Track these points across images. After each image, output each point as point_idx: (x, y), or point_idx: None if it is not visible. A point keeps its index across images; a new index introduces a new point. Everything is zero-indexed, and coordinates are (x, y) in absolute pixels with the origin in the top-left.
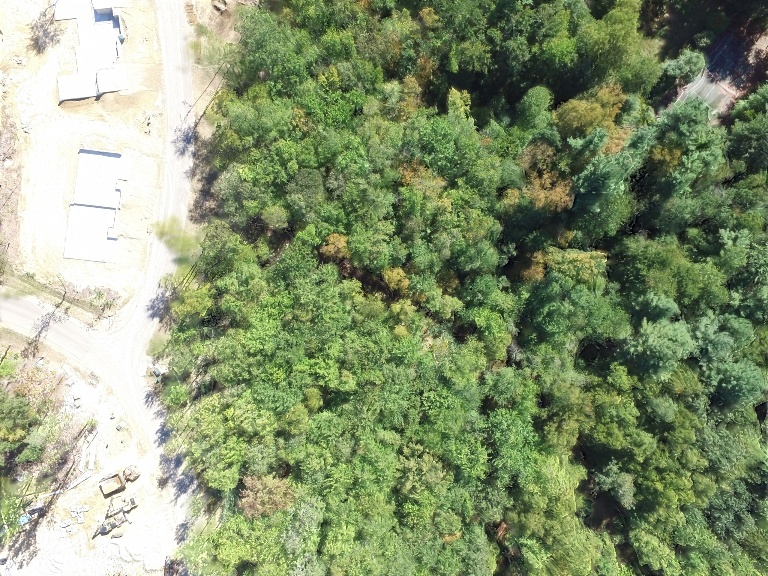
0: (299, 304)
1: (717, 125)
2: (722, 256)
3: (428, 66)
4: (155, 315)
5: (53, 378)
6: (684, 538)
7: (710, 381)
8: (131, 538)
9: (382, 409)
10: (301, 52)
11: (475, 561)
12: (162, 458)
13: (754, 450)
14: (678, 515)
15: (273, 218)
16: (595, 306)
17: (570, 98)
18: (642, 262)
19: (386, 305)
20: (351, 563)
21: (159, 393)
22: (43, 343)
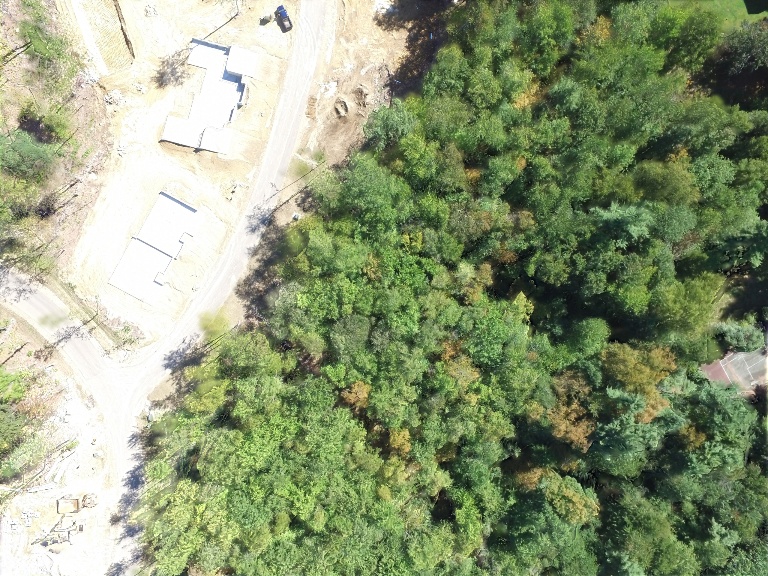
0: (303, 437)
1: (751, 406)
2: (705, 546)
3: (507, 256)
4: (169, 366)
5: (55, 386)
6: None
7: None
8: (66, 558)
9: (339, 560)
10: (397, 204)
11: None
12: (123, 497)
13: None
14: None
15: (311, 346)
16: (570, 547)
17: (625, 340)
18: (630, 516)
19: (381, 454)
20: None
21: (144, 437)
22: (58, 351)
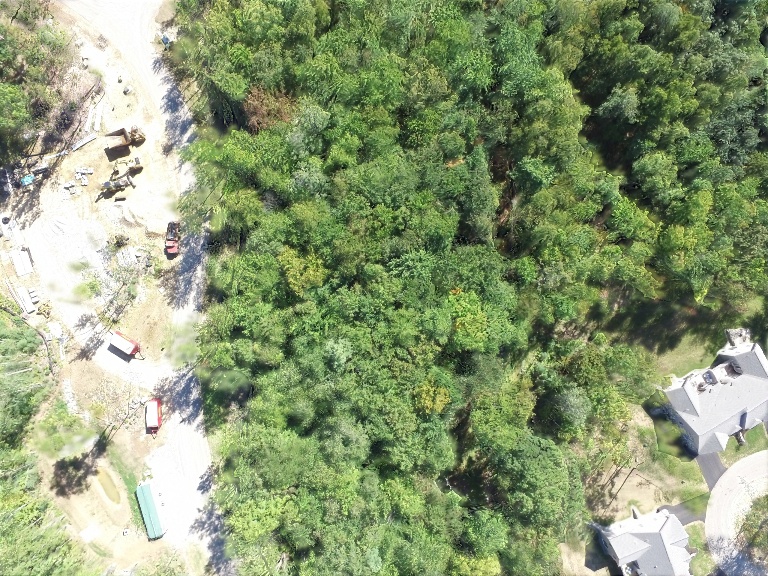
0: None
1: None
2: None
3: None
4: None
5: (62, 39)
6: (687, 149)
7: None
8: (134, 202)
9: (389, 15)
10: None
11: (478, 185)
12: (168, 124)
13: (758, 58)
14: (682, 128)
15: None
16: None
17: None
18: None
19: None
20: (355, 173)
21: (167, 60)
22: (54, 4)
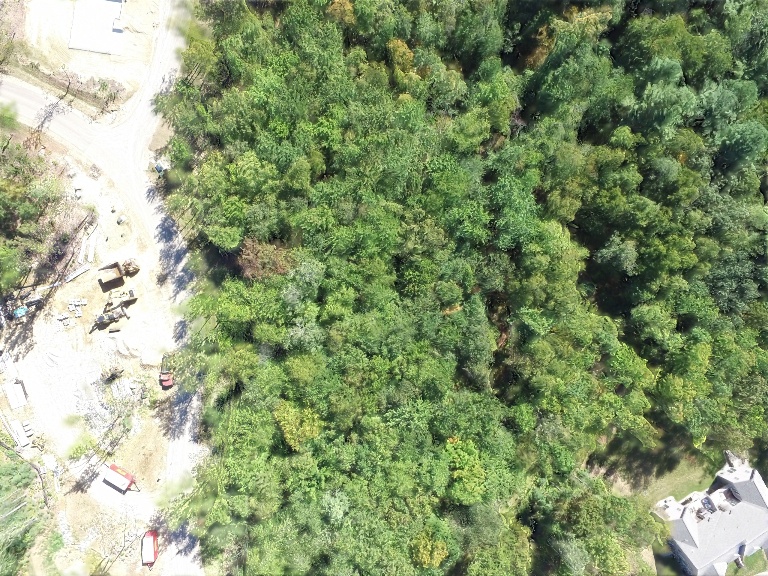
0: (304, 59)
1: None
2: (727, 27)
3: None
4: (159, 110)
5: (55, 169)
6: (686, 303)
7: (714, 143)
8: (129, 334)
9: (385, 168)
10: None
11: (476, 334)
12: (162, 254)
13: (757, 213)
14: (681, 281)
15: None
16: (600, 70)
17: None
18: None
19: None
20: (351, 327)
21: (161, 188)
22: (46, 134)
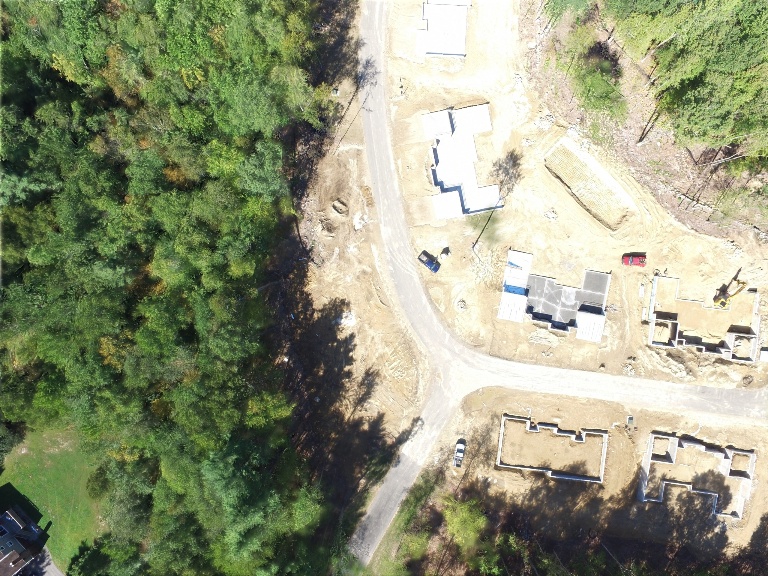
0: None
1: None
2: None
3: None
4: None
5: None
6: None
7: None
8: None
9: None
10: (226, 109)
11: None
12: None
13: None
14: None
15: None
16: None
17: None
18: None
19: None
20: None
21: None
22: None
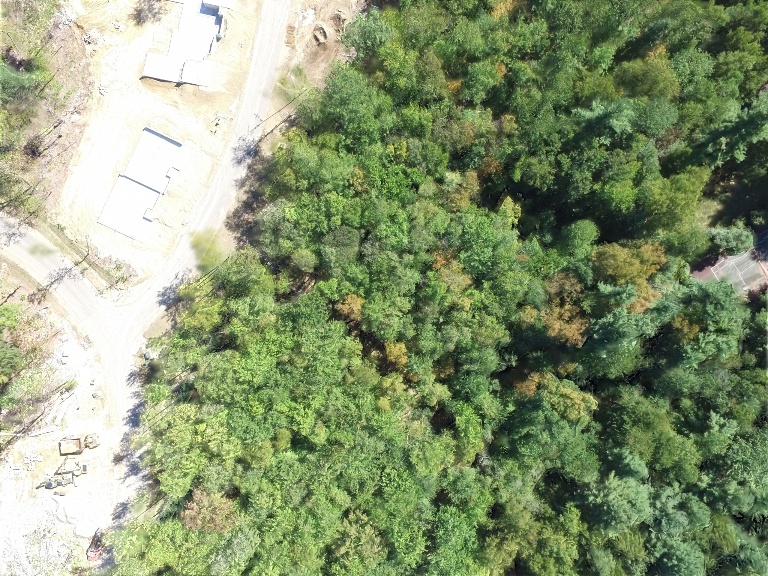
0: (299, 350)
1: (744, 306)
2: (705, 437)
3: (493, 165)
4: (163, 303)
5: (50, 329)
6: None
7: (654, 551)
8: (72, 500)
9: (342, 472)
10: (380, 116)
11: None
12: (125, 436)
13: None
14: None
15: (302, 261)
16: (571, 444)
17: (614, 241)
18: (629, 415)
19: (379, 371)
20: None
21: (143, 375)
22: (52, 294)
